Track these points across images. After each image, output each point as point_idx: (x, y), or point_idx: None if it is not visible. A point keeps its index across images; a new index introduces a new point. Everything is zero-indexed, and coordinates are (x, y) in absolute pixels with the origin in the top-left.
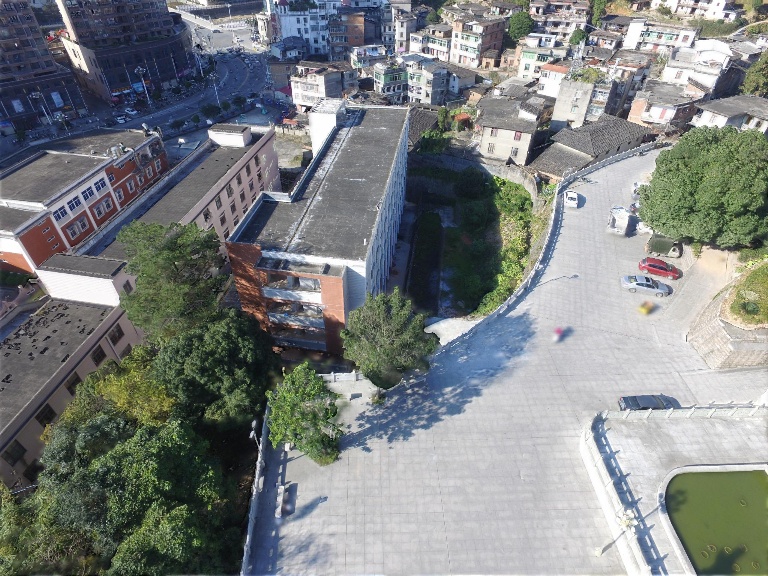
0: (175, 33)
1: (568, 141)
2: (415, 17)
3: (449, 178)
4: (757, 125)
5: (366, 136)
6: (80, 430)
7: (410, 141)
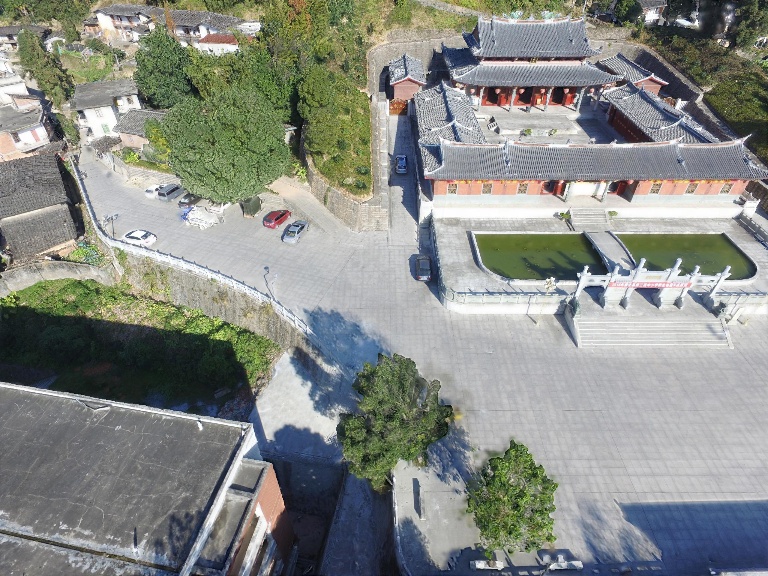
0: None
1: (16, 208)
2: None
3: None
4: (129, 102)
5: None
6: None
7: None
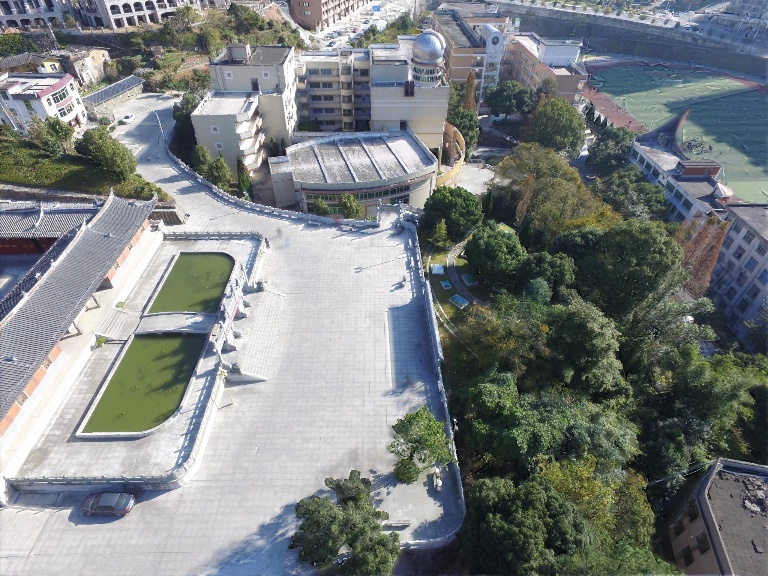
0: None
1: None
2: None
3: None
4: None
5: None
6: (605, 464)
7: None
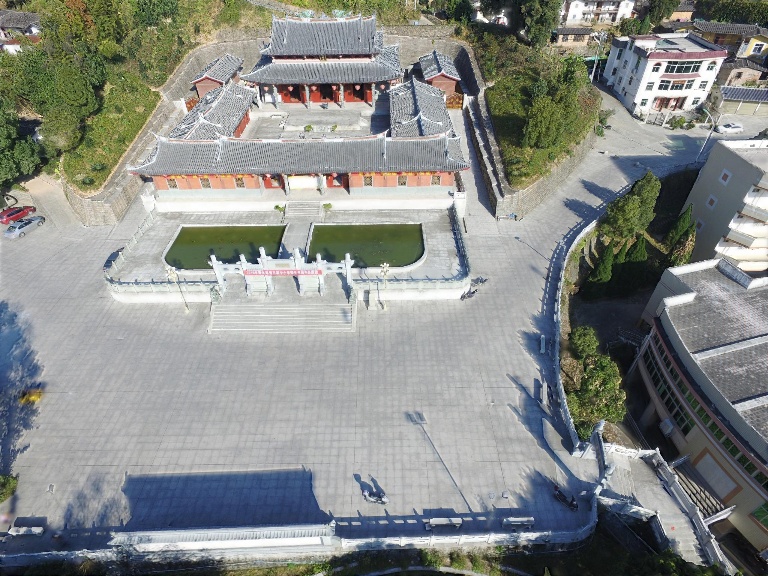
0: None
1: None
2: None
3: None
4: None
5: None
6: None
7: None
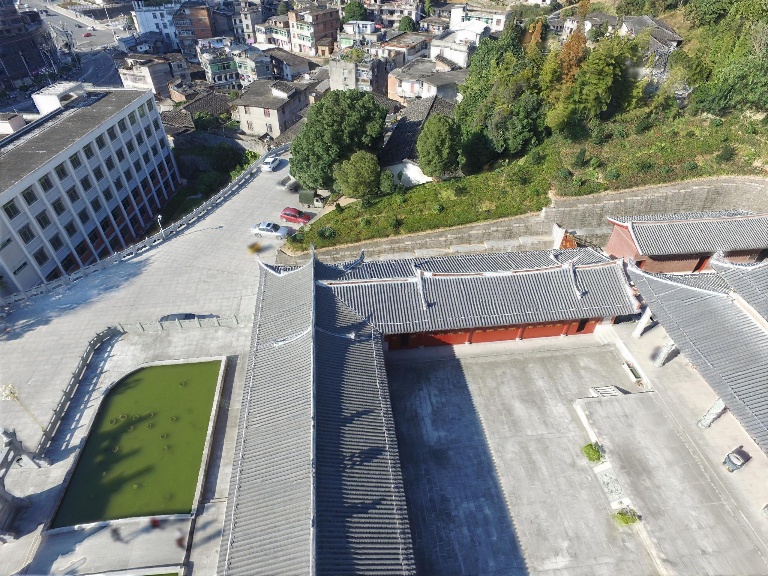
0: (27, 31)
1: None
2: (260, 9)
3: (211, 155)
4: None
5: (86, 115)
6: None
7: (192, 123)
